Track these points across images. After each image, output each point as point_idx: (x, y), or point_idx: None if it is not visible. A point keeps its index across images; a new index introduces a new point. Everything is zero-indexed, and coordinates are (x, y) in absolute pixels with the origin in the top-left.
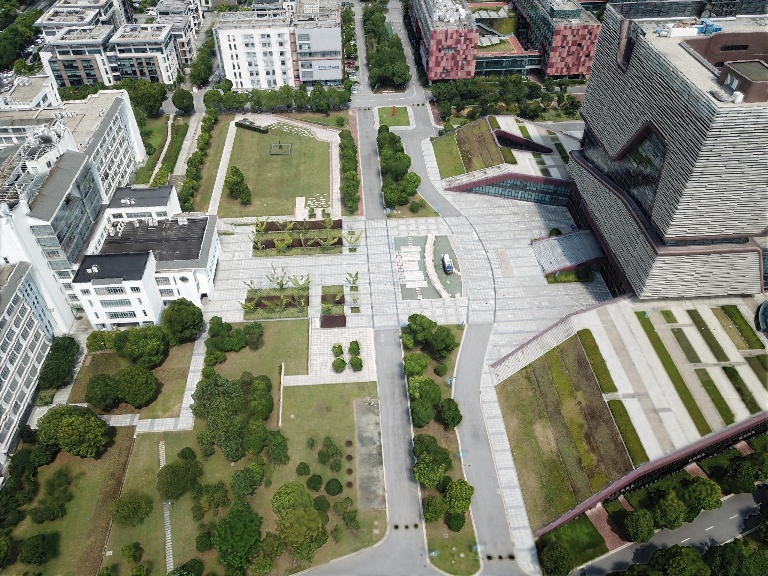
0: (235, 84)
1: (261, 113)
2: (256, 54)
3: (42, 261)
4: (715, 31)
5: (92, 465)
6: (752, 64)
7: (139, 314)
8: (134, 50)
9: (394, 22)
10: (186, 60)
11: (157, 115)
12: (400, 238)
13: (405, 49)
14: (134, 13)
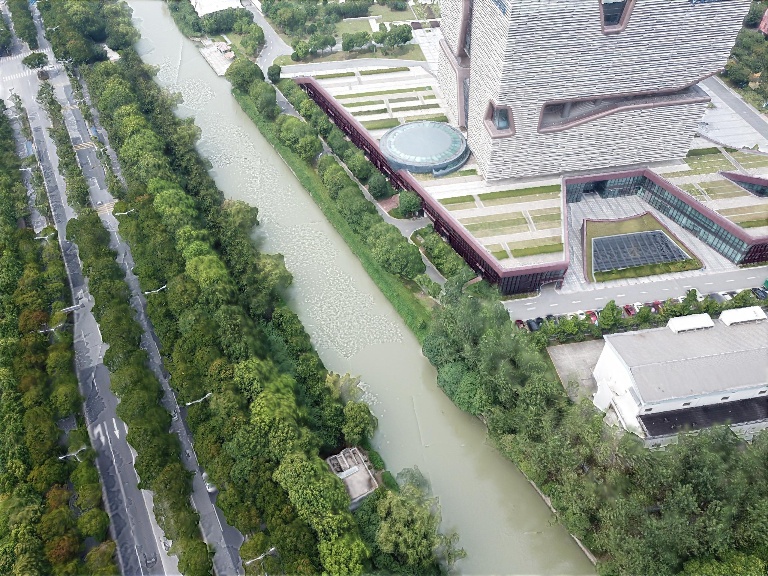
0: None
1: None
2: None
3: None
4: None
5: None
6: None
7: None
8: None
9: None
10: None
11: None
12: None
13: None
14: None
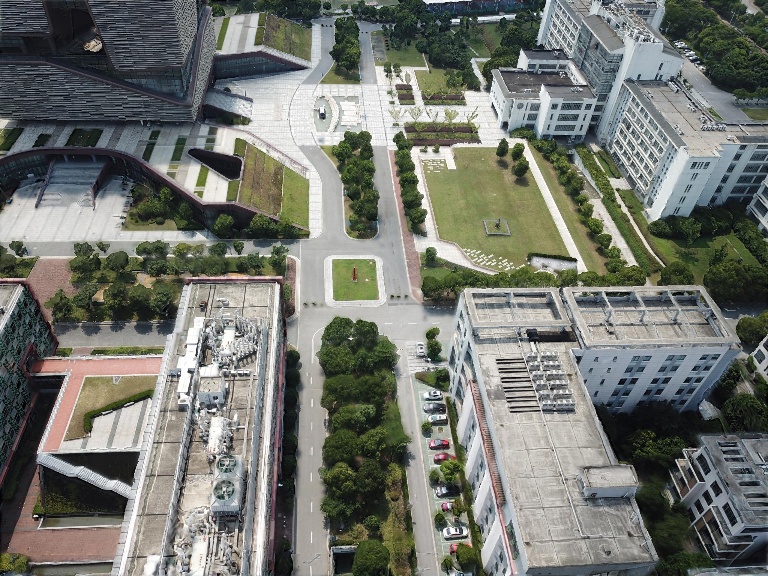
0: None
1: None
2: None
3: None
4: None
5: None
6: None
7: None
8: None
9: None
10: None
11: None
12: (357, 132)
13: (310, 543)
14: None
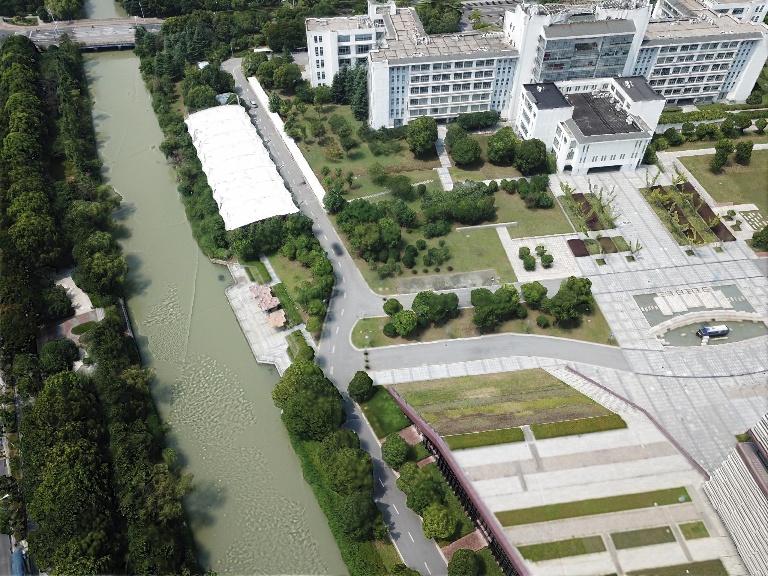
0: None
1: None
2: None
3: (531, 63)
4: None
5: (410, 158)
6: None
7: (528, 136)
8: None
9: None
10: None
11: None
12: (737, 290)
13: None
14: None
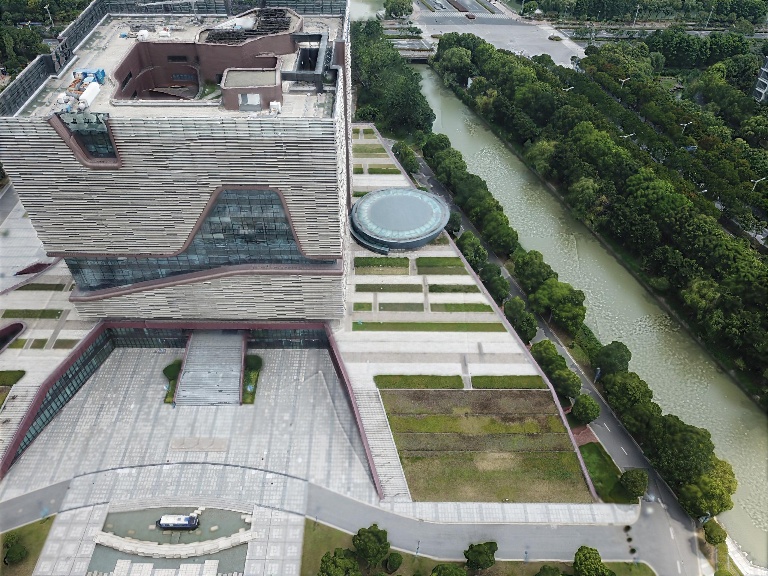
0: None
1: None
2: None
3: None
4: (102, 76)
5: None
6: (232, 76)
7: None
8: None
9: None
10: None
11: None
12: None
13: None
14: None
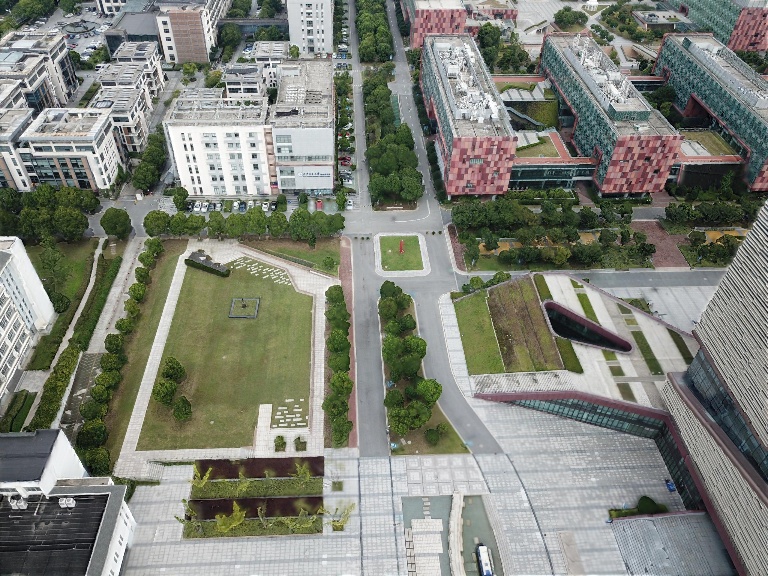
0: (193, 190)
1: (223, 240)
2: (220, 156)
3: None
4: None
5: None
6: None
7: None
8: (55, 148)
9: (401, 95)
10: (134, 147)
11: (82, 238)
12: (411, 499)
13: (415, 138)
14: (81, 69)
